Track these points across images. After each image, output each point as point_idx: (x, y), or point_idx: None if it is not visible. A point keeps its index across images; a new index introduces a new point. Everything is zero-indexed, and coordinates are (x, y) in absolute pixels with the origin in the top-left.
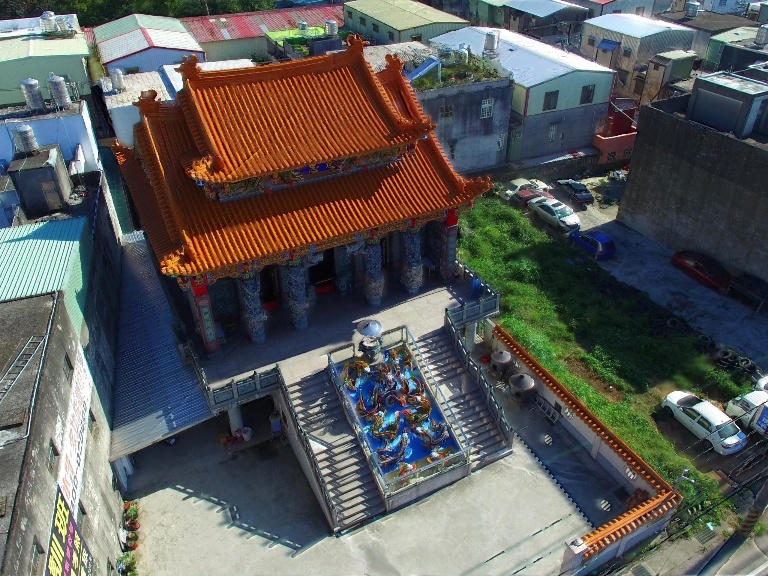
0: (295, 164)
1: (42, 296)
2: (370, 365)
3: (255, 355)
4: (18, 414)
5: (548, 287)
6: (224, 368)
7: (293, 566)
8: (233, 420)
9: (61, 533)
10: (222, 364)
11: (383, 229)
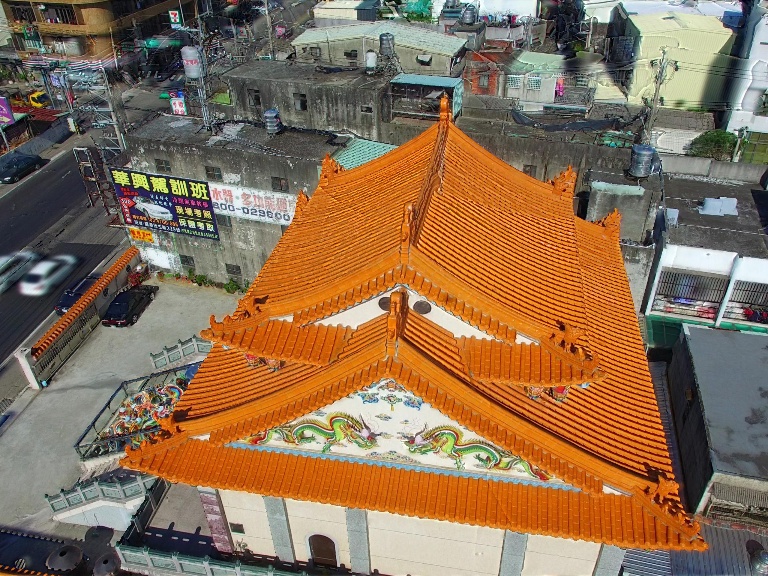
0: (296, 224)
1: None
2: None
3: None
4: (221, 143)
5: None
6: None
7: None
8: None
9: (193, 191)
10: None
11: None
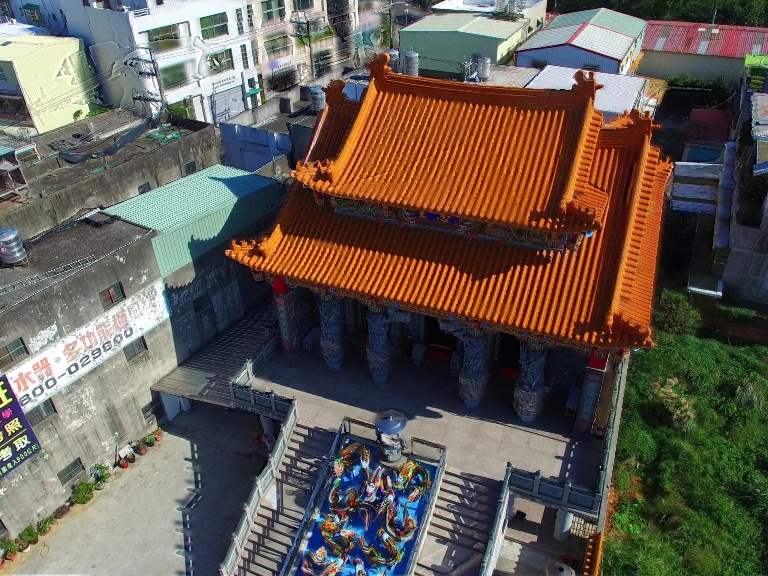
0: (400, 202)
1: (144, 229)
2: (381, 462)
3: (315, 377)
4: None
5: None
6: (282, 371)
7: None
8: (263, 423)
9: None
10: (286, 367)
11: (489, 323)
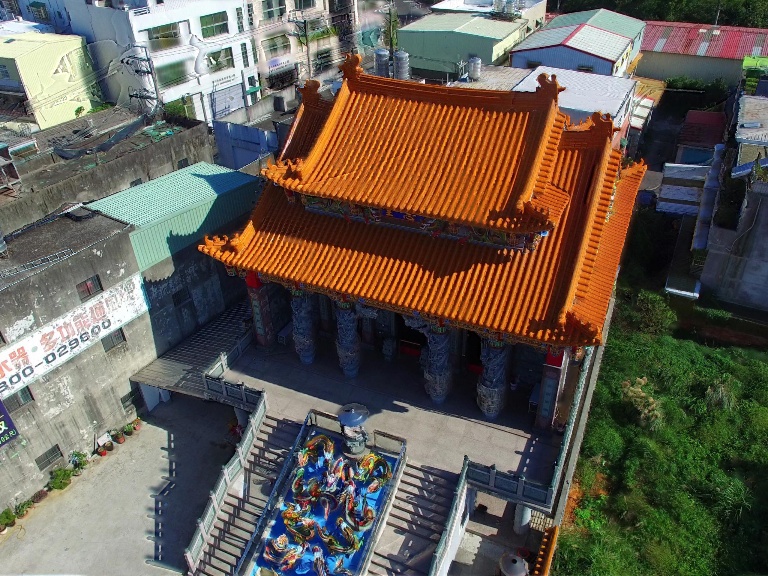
0: (365, 201)
1: (123, 223)
2: (345, 453)
3: (288, 371)
4: None
5: (739, 542)
6: (256, 364)
7: (137, 569)
8: (237, 414)
9: None
10: (260, 360)
11: (450, 320)
